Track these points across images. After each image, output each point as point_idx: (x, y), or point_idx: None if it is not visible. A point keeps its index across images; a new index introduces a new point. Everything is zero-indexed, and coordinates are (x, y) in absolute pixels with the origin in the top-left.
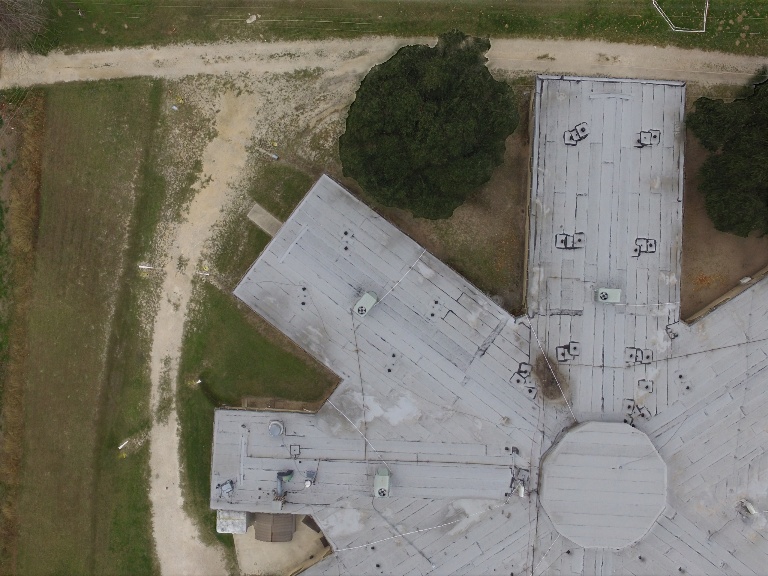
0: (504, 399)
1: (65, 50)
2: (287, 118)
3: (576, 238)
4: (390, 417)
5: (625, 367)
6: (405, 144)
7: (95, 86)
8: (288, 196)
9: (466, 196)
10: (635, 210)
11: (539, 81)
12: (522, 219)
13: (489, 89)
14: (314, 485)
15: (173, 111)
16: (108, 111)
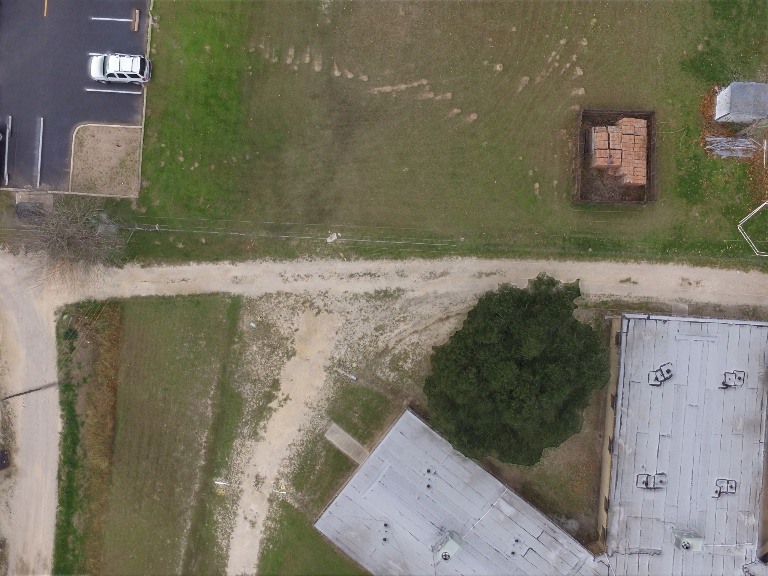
0: None
1: (142, 263)
2: (366, 339)
3: (657, 479)
4: None
5: None
6: (497, 406)
7: (172, 301)
8: (366, 417)
9: None
10: (717, 451)
11: (625, 320)
12: (599, 444)
13: (582, 350)
14: None
15: (251, 327)
16: (185, 327)
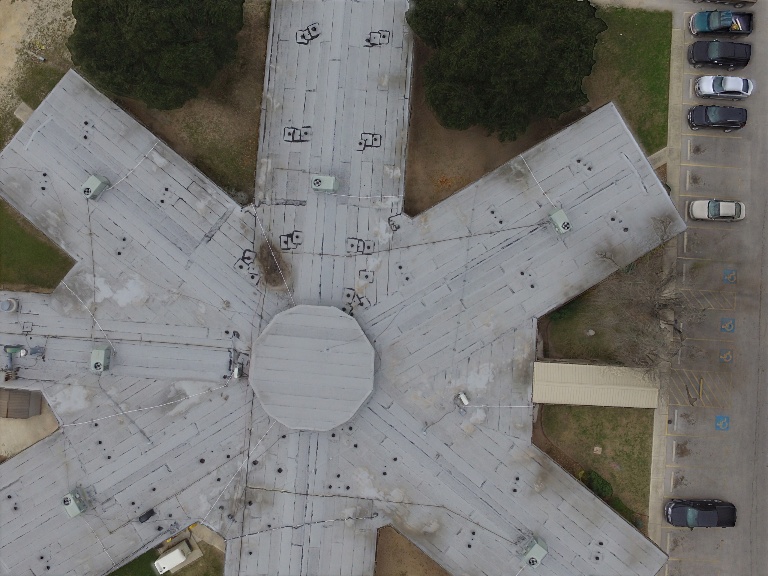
0: (226, 283)
1: None
2: (55, 23)
3: (303, 131)
4: (119, 298)
5: (343, 255)
6: (121, 30)
7: None
8: None
9: (198, 89)
10: (362, 106)
11: None
12: None
13: None
14: (44, 362)
15: None
16: None
